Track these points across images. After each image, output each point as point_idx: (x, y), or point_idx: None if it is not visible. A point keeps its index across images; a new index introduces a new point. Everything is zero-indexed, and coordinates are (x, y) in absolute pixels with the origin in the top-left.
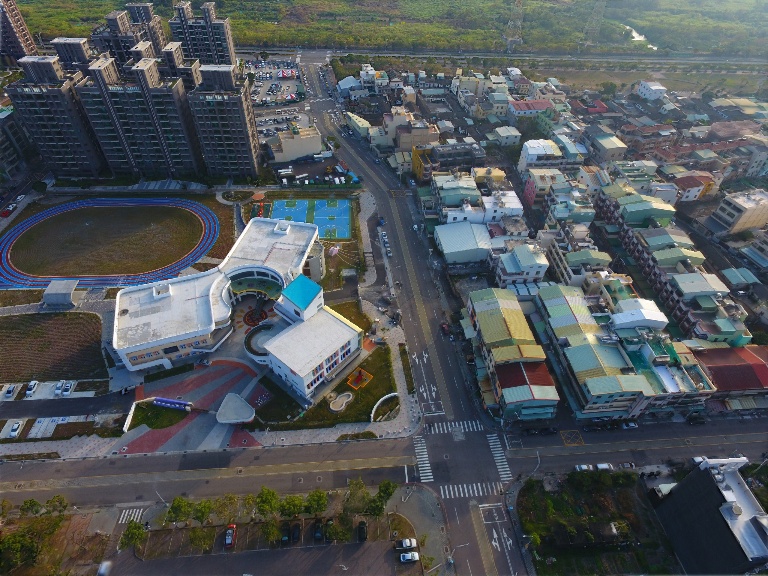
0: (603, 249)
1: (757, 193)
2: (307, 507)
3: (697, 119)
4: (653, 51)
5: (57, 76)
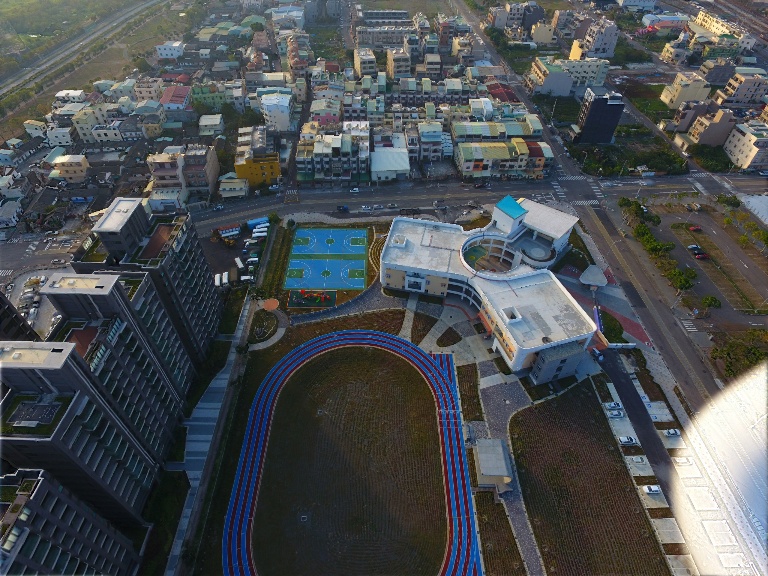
0: None
1: (359, 51)
2: None
3: (225, 50)
4: (67, 33)
5: None
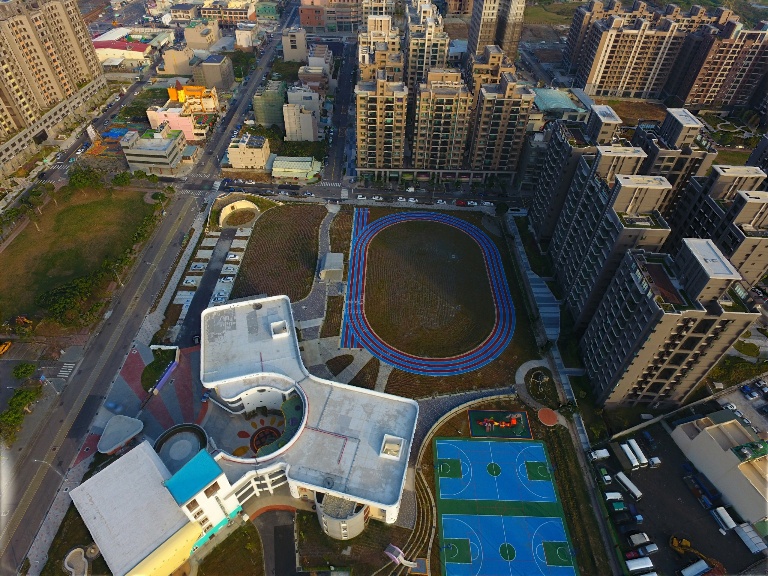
0: None
1: None
2: None
3: None
4: None
5: (598, 137)
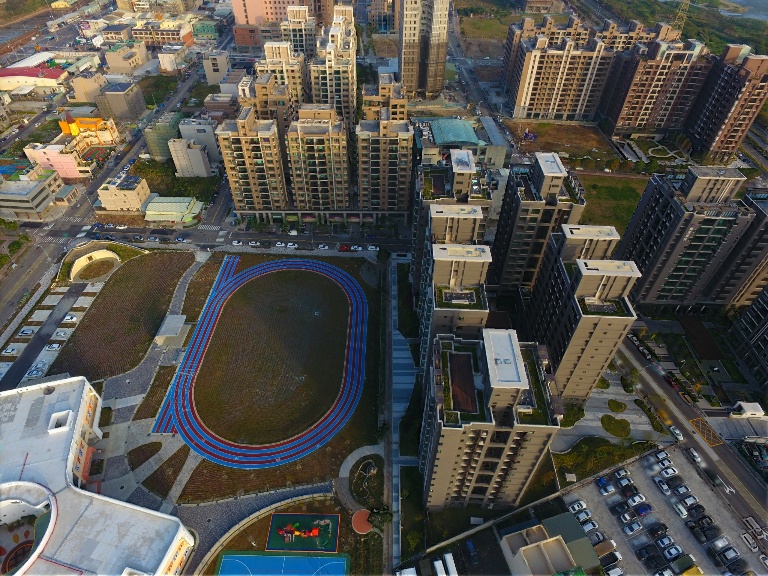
0: None
1: None
2: None
3: None
4: None
5: (454, 188)
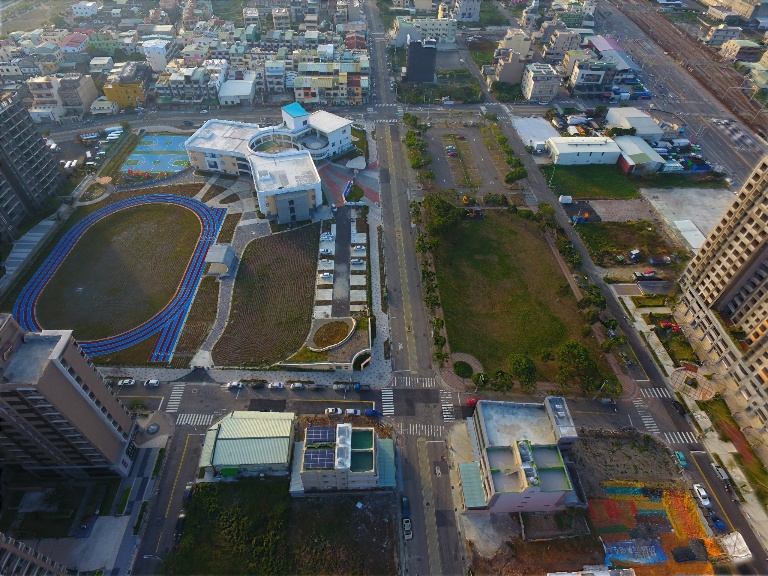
0: None
1: (246, 11)
2: (414, 135)
3: (137, 11)
4: None
5: None
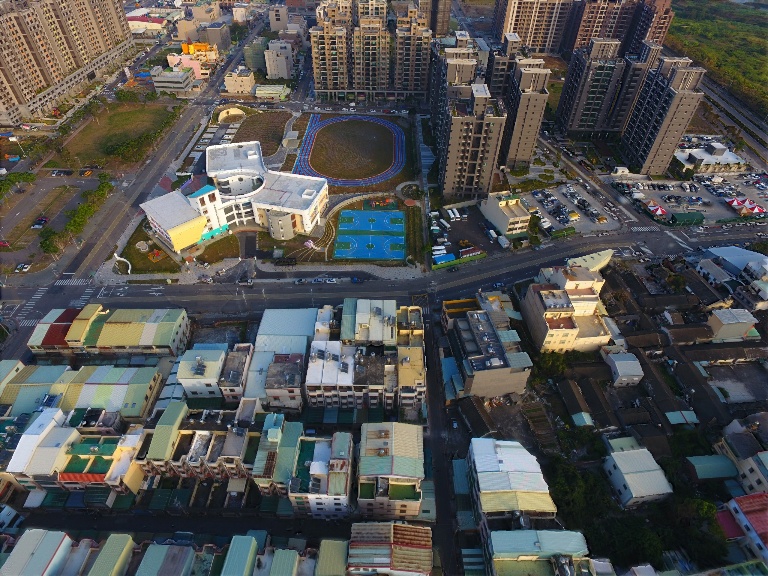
0: (243, 535)
1: None
2: None
3: None
4: None
5: None
